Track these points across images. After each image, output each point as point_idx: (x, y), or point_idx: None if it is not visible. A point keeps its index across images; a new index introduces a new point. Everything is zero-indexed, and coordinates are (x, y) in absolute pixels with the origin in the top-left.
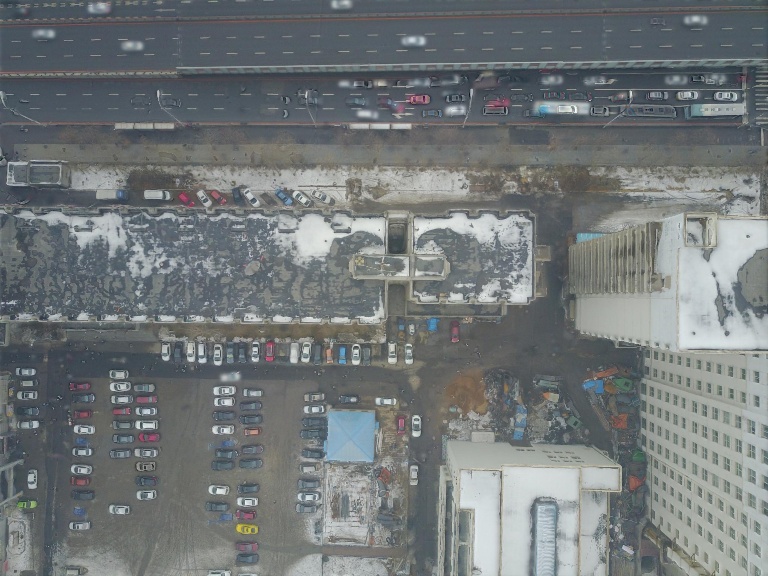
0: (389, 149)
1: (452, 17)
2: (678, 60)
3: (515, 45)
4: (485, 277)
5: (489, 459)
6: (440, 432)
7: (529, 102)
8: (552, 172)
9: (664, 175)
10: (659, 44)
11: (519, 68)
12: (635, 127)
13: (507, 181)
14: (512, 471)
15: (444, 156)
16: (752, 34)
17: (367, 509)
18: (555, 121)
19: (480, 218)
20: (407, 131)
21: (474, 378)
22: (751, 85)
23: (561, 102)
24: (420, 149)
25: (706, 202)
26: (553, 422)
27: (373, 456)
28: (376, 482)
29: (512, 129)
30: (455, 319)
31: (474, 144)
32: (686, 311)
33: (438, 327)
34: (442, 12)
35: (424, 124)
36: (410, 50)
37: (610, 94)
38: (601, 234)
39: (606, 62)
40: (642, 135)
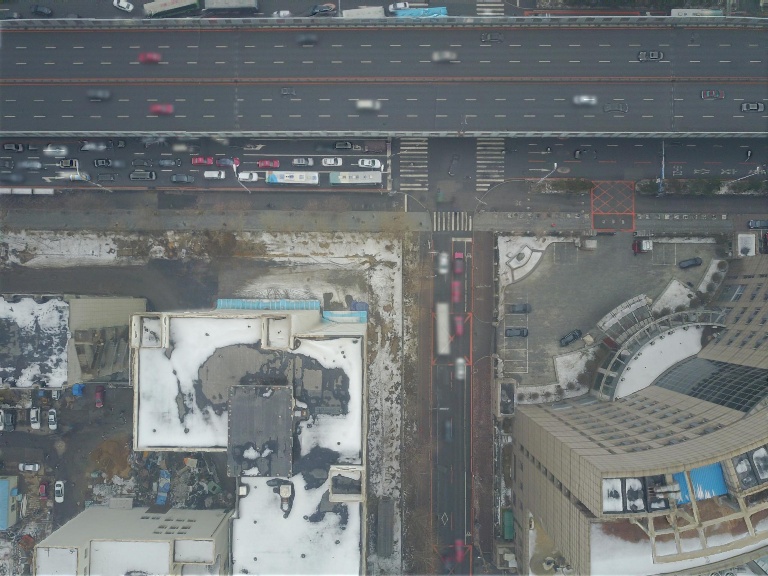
0: (38, 213)
1: (88, 84)
2: (298, 131)
3: (150, 113)
4: (25, 361)
5: (88, 532)
6: (84, 497)
7: (178, 167)
8: (199, 237)
9: (308, 240)
10: (289, 114)
11: (152, 136)
12: (283, 192)
13: (155, 246)
14: (103, 546)
15: (92, 220)
16: (377, 105)
17: (9, 575)
18: (204, 186)
19: (20, 302)
20: (46, 197)
21: (119, 443)
22: (396, 152)
23: (210, 167)
24: (69, 213)
25: (350, 267)
26: (195, 487)
27: (9, 523)
28: (19, 548)
29: (161, 193)
30: (101, 384)
31: (122, 208)
32: (147, 408)
33: (83, 392)
34: (78, 79)
35: (67, 189)
36: (48, 116)
37: (258, 159)
38: (241, 300)
39: (229, 132)
40: (289, 200)
